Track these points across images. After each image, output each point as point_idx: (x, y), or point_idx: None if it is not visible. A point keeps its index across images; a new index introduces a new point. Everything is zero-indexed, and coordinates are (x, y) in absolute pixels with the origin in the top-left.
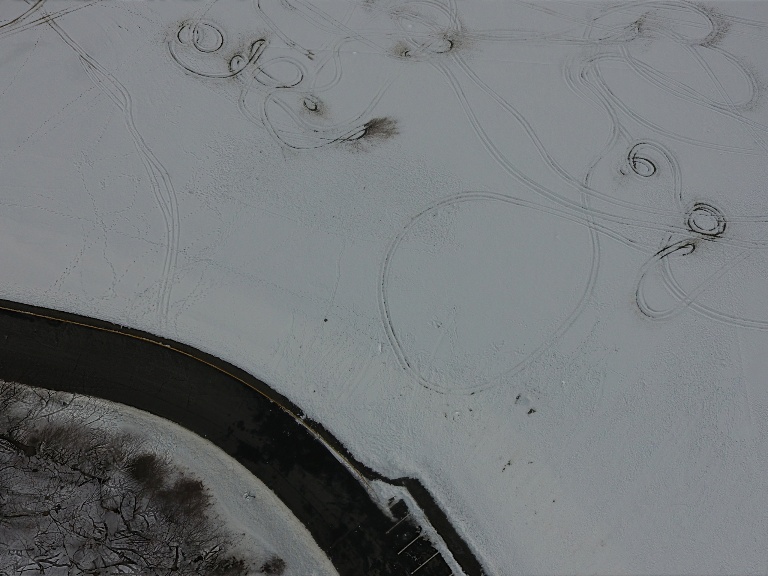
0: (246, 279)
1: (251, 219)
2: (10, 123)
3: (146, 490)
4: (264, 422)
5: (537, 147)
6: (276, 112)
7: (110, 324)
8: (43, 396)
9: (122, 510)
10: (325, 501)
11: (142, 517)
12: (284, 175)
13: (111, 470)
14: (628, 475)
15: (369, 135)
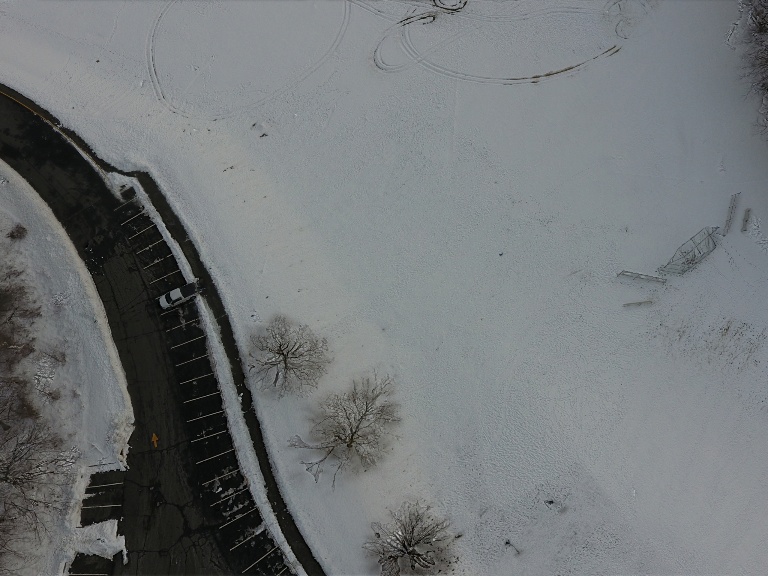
0: (33, 28)
1: None
2: None
3: None
4: (27, 129)
5: None
6: None
7: None
8: None
9: None
10: (68, 187)
11: None
12: None
13: None
14: (336, 184)
15: None
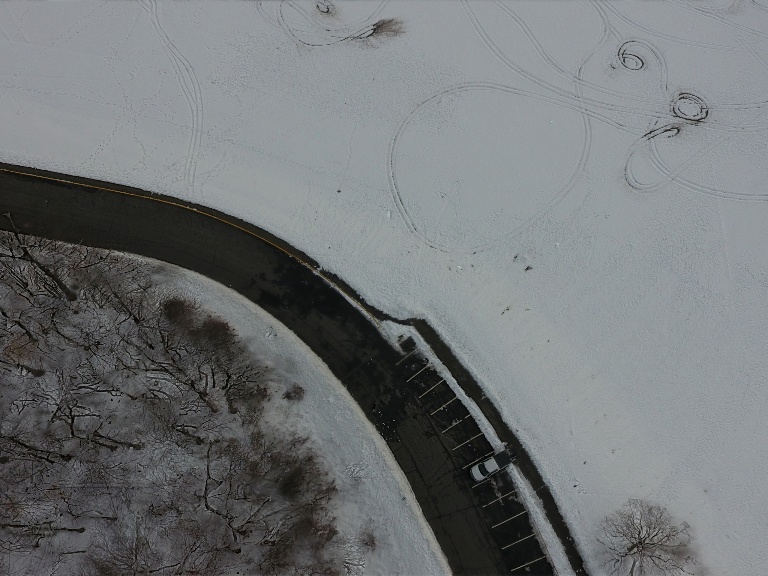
0: (265, 156)
1: (269, 105)
2: (44, 23)
3: (177, 330)
4: (284, 274)
5: (533, 44)
6: (291, 14)
7: (142, 191)
8: (82, 251)
9: (156, 346)
10: (340, 339)
11: (174, 351)
12: (299, 68)
13: (145, 312)
14: (616, 322)
15: (378, 34)
